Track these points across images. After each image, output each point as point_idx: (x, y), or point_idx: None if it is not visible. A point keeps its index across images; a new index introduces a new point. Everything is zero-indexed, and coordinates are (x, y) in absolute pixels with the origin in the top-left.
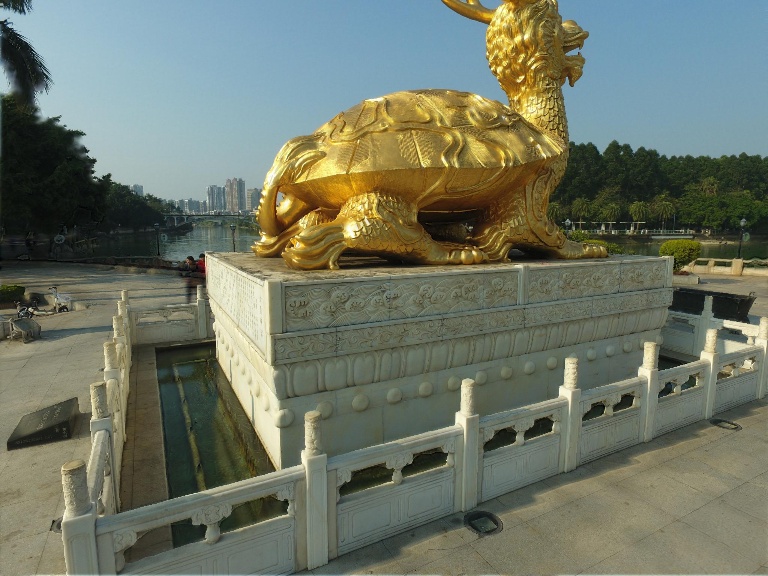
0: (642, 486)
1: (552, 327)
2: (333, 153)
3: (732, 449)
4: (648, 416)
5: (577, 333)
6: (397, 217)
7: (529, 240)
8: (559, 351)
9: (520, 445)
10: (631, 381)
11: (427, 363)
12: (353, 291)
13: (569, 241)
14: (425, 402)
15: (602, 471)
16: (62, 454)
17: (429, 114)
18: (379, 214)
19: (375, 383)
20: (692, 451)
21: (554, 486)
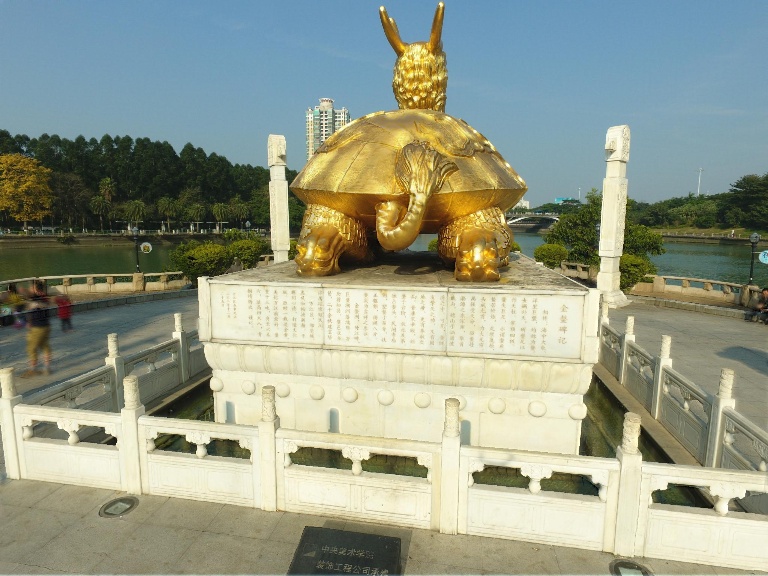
0: None
1: None
2: (465, 167)
3: None
4: None
5: None
6: None
7: None
8: None
9: None
10: None
11: None
12: None
13: None
14: None
15: None
16: (450, 575)
17: None
18: None
19: None
20: None
21: None
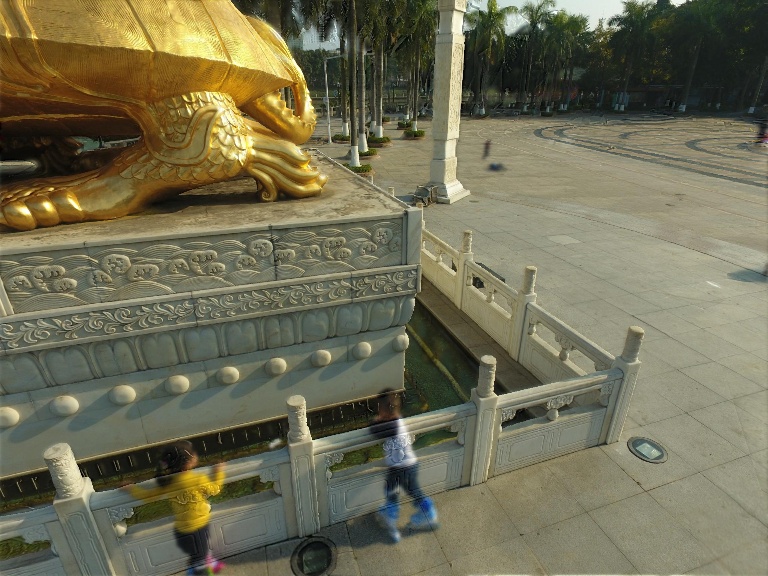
0: None
1: None
2: None
3: None
4: None
5: None
6: None
7: None
8: None
9: None
10: None
11: None
12: None
13: None
14: None
15: None
16: None
17: None
18: None
19: None
20: None
21: None
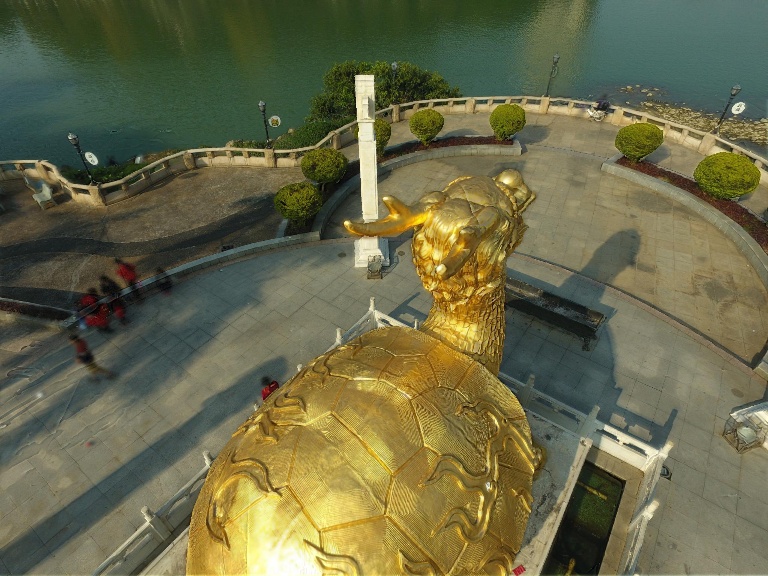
0: None
1: None
2: None
3: None
4: None
5: None
6: None
7: None
8: None
9: None
10: None
11: None
12: None
13: None
14: None
15: None
16: None
17: None
18: None
19: None
20: None
21: None
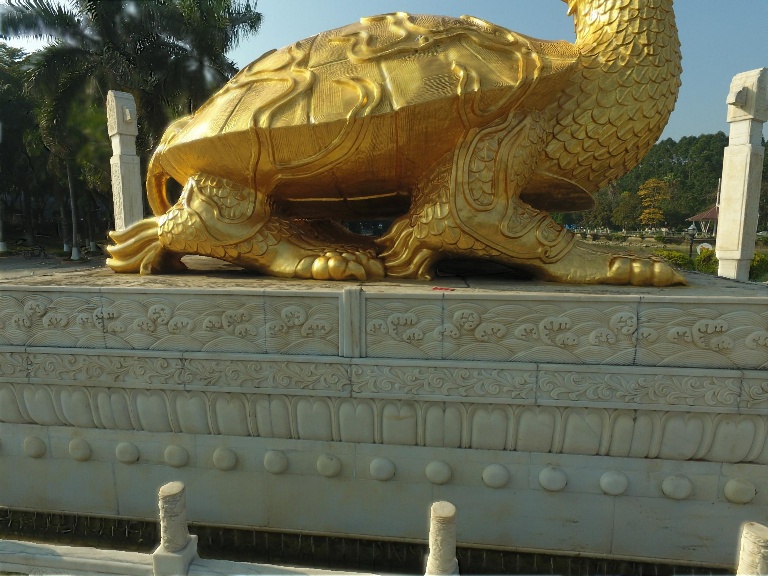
0: None
1: (429, 407)
2: None
3: None
4: None
5: (501, 429)
6: (212, 207)
7: (461, 245)
8: (458, 454)
9: None
10: None
11: (170, 419)
12: (52, 303)
13: (581, 249)
14: (177, 474)
15: None
16: None
17: (291, 56)
18: (186, 204)
19: (99, 429)
20: None
21: None
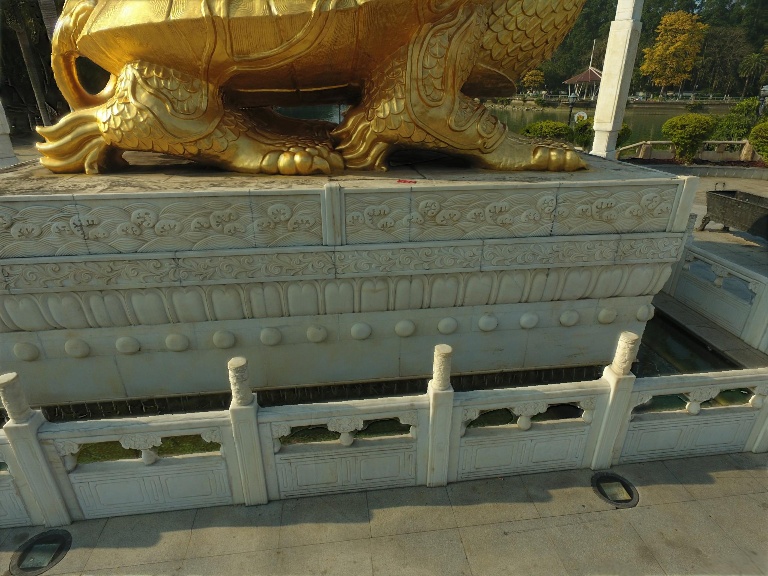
0: (308, 568)
1: (399, 280)
2: (98, 2)
3: (553, 545)
4: (432, 454)
5: (454, 292)
6: (163, 101)
7: (414, 138)
8: (420, 313)
9: (145, 464)
10: (391, 402)
11: (168, 312)
12: (18, 214)
13: (511, 140)
14: (180, 357)
15: (295, 519)
16: None
17: None
18: (131, 97)
19: (94, 328)
20: (480, 526)
21: (200, 523)
